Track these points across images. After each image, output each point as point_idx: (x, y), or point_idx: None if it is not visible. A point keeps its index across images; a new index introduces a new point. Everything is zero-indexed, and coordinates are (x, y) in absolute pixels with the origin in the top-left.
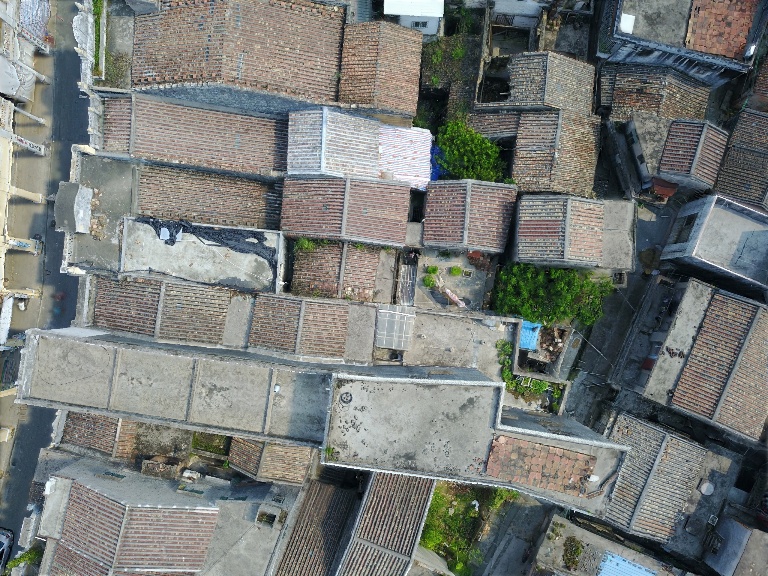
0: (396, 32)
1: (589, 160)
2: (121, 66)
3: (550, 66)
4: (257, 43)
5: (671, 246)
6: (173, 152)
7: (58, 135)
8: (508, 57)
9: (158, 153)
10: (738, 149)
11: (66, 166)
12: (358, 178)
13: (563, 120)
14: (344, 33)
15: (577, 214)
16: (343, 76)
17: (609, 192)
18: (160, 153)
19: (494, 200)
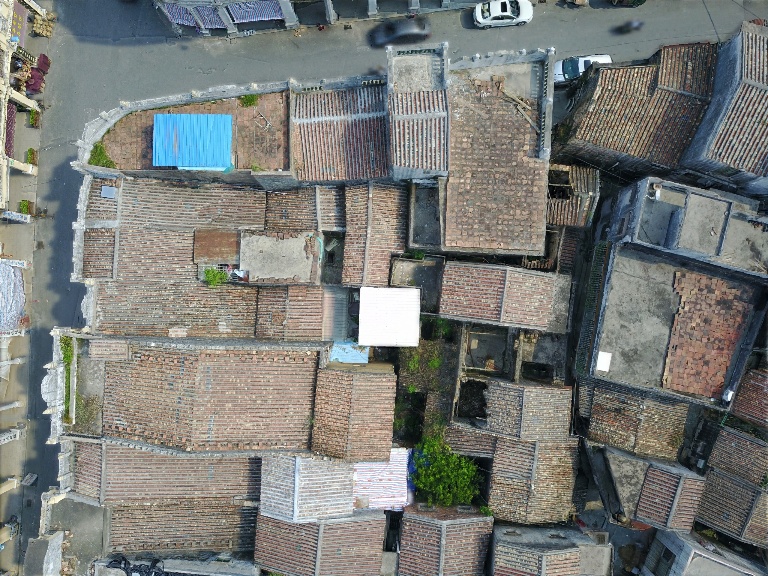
0: (369, 382)
1: (566, 484)
2: (92, 409)
3: (526, 401)
4: (228, 402)
5: (649, 574)
6: (145, 494)
7: (34, 414)
8: (484, 381)
9: (129, 497)
10: (717, 474)
11: (42, 445)
12: (332, 522)
13: (540, 450)
14: (317, 378)
15: (552, 568)
16: (316, 423)
17: (589, 488)
18: (131, 497)
19: (470, 535)
